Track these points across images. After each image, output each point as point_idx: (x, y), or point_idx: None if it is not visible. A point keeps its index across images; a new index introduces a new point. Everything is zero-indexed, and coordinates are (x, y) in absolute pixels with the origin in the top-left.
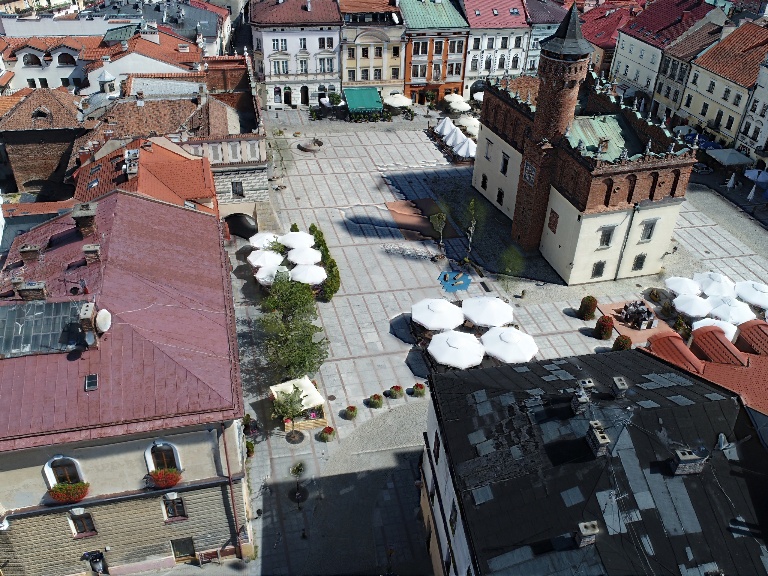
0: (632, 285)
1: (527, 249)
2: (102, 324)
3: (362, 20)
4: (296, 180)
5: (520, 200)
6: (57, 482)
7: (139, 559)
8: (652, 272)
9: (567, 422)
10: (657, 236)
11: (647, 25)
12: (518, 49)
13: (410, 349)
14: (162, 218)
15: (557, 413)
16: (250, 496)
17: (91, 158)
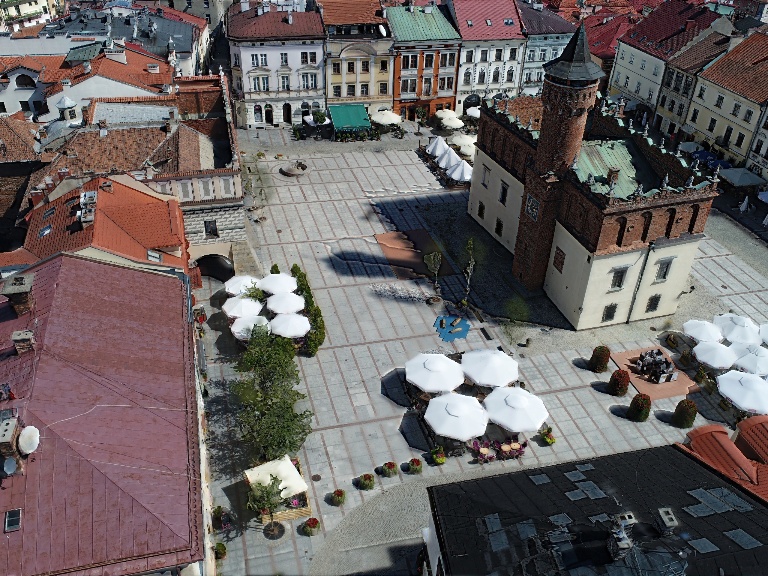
0: (646, 328)
1: (530, 288)
2: (27, 444)
3: (347, 32)
4: (278, 210)
5: (522, 235)
6: None
7: None
8: (667, 313)
9: (603, 569)
10: (673, 275)
11: (648, 34)
12: (513, 61)
13: (404, 413)
14: (115, 285)
15: (590, 555)
16: None
17: (45, 199)
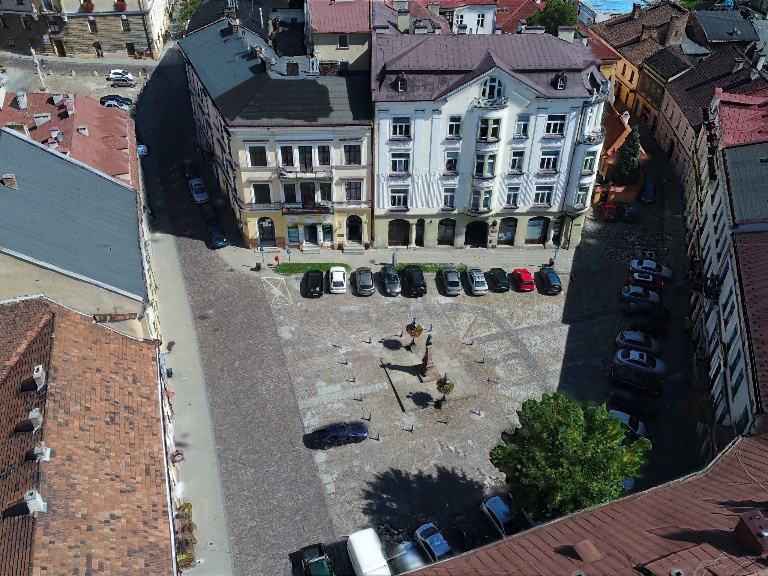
0: None
1: None
2: None
3: None
4: None
5: None
6: (84, 2)
7: (114, 51)
8: None
9: None
10: None
11: None
12: None
13: None
14: None
15: None
16: (162, 50)
17: None
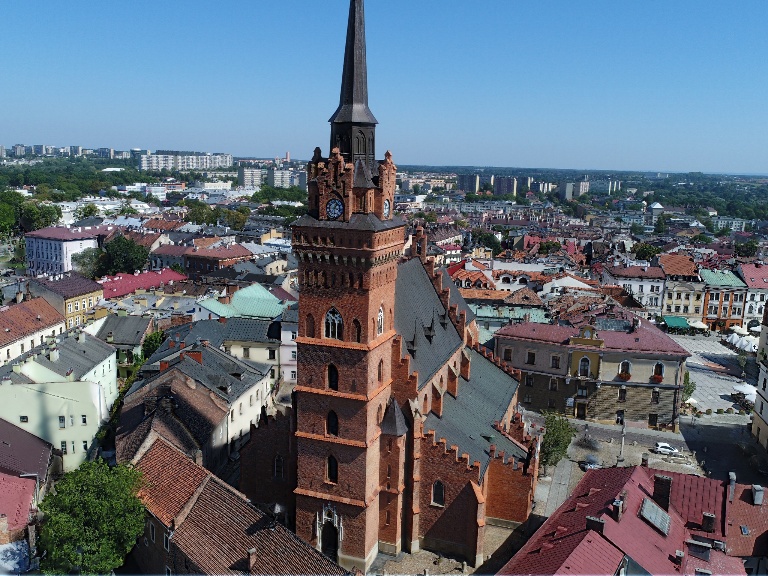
0: None
1: None
2: (639, 324)
3: (676, 279)
4: None
5: None
6: (621, 372)
7: (636, 420)
8: None
9: None
10: None
11: None
12: None
13: None
14: None
15: None
16: None
17: (566, 311)
